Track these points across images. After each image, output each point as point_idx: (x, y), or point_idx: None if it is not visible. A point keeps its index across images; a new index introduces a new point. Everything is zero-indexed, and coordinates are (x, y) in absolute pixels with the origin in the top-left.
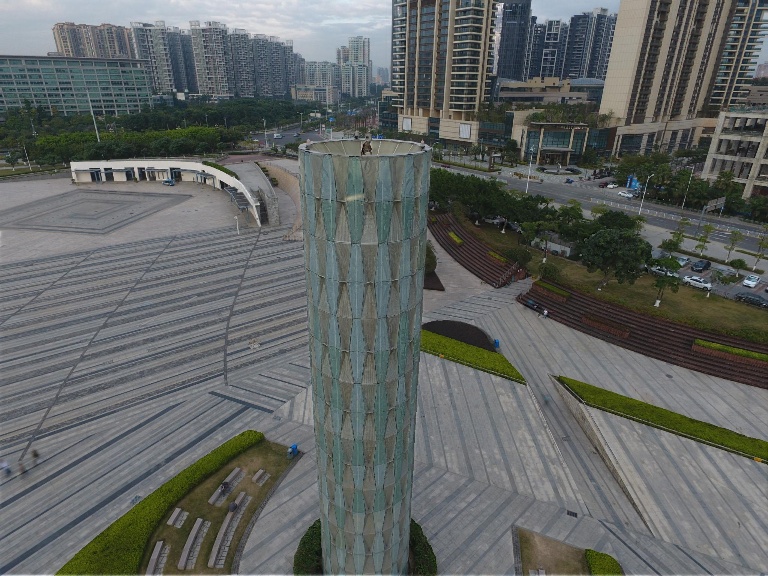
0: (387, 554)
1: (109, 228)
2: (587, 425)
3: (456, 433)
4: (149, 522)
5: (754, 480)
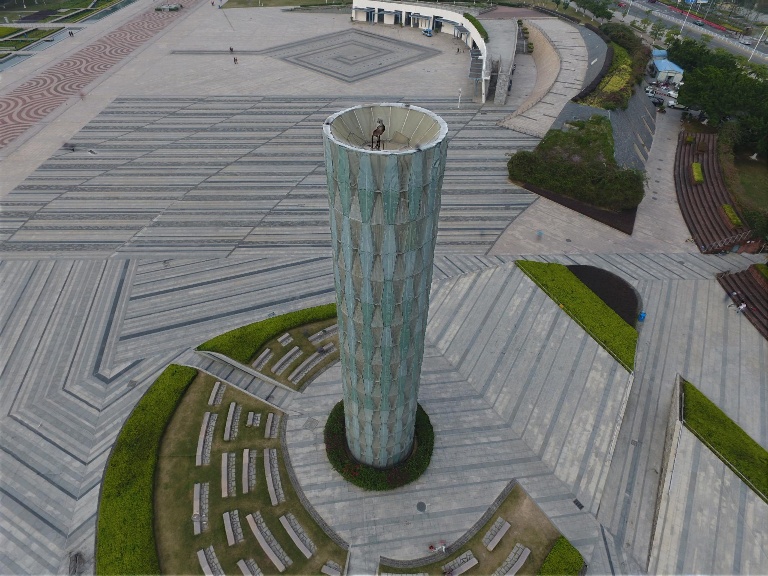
0: (377, 439)
1: (356, 77)
2: (669, 444)
3: (523, 382)
4: (267, 334)
5: None
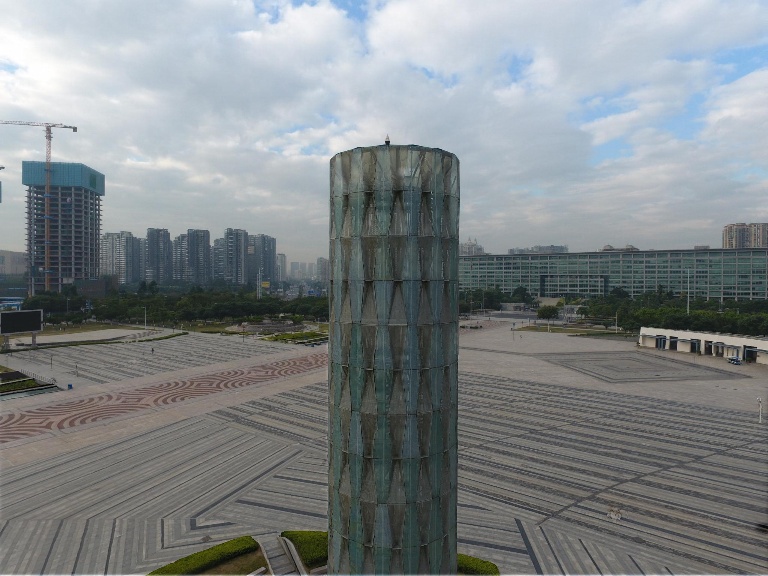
0: None
1: (621, 380)
2: None
3: None
4: None
5: None
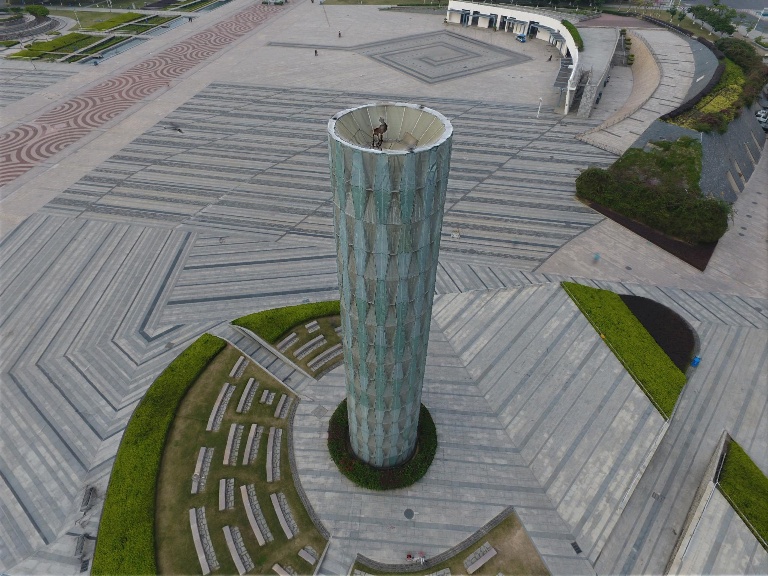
0: (372, 437)
1: (438, 78)
2: (696, 505)
3: (543, 408)
4: (297, 318)
5: None
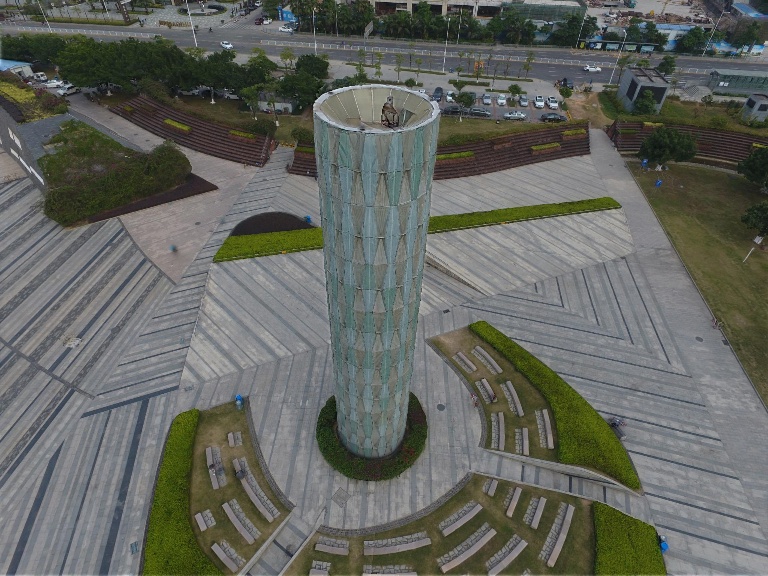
0: None
1: None
2: None
3: None
4: (187, 544)
5: (508, 236)
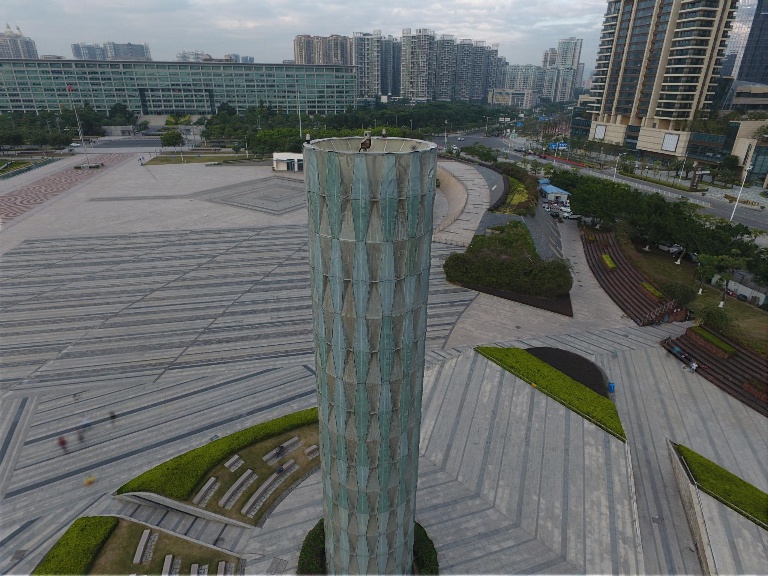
0: (373, 561)
1: (284, 210)
2: (692, 513)
3: (518, 471)
4: (211, 459)
5: None
